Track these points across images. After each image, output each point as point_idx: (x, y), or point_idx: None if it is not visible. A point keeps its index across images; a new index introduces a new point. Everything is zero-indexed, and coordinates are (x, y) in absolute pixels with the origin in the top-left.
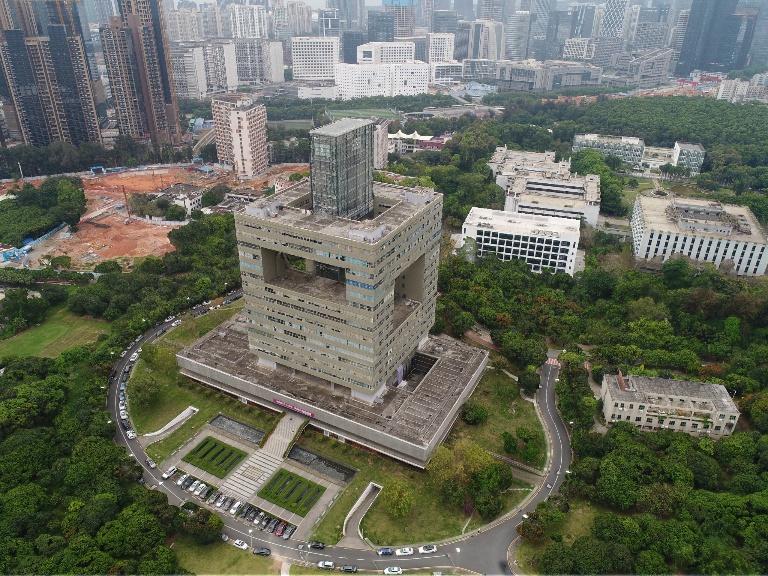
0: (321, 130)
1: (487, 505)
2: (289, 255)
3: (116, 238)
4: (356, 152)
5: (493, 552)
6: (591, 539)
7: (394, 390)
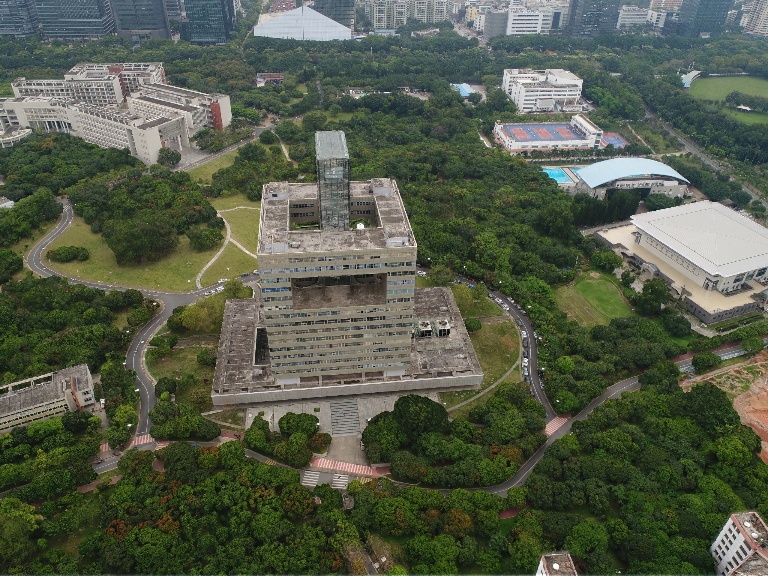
0: (339, 135)
1: (180, 306)
2: (557, 444)
3: None
4: None
5: (173, 303)
6: (114, 298)
7: None
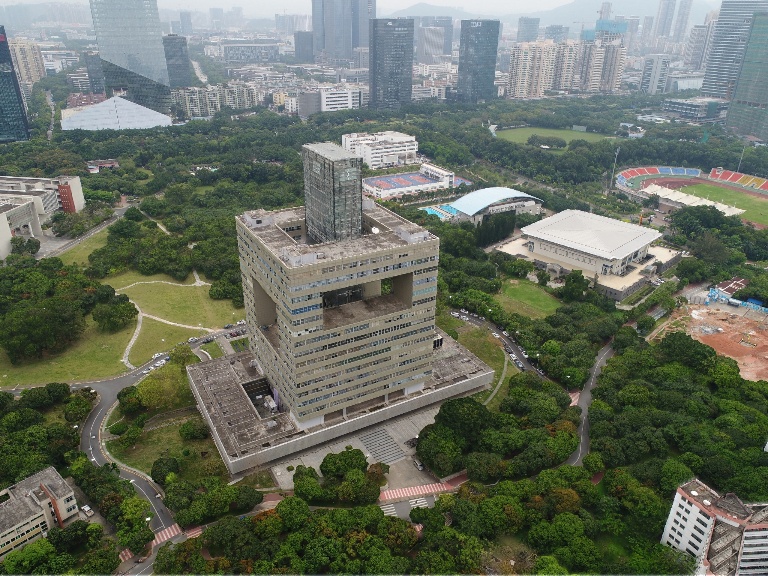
0: (329, 145)
1: (125, 388)
2: (595, 409)
3: (765, 346)
4: (318, 176)
5: (109, 390)
6: (37, 395)
7: (255, 376)
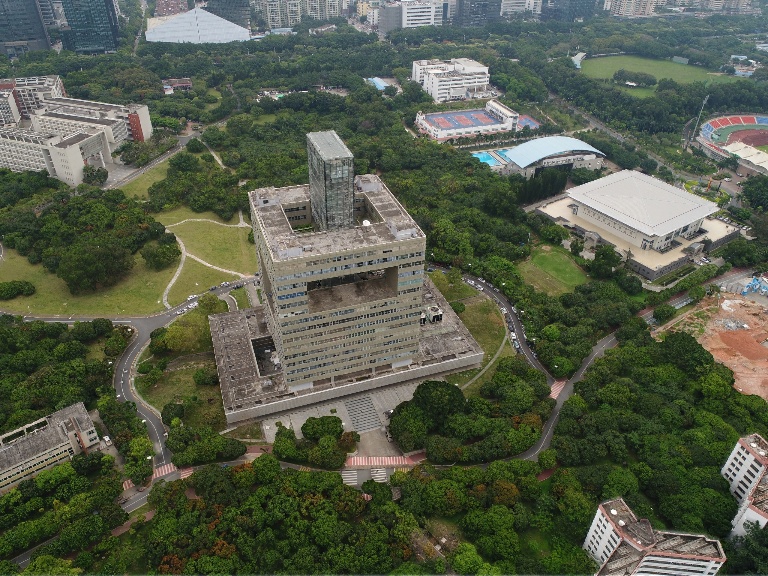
0: (332, 135)
1: (157, 329)
2: (568, 405)
3: None
4: None
5: (146, 327)
6: (84, 329)
7: (265, 333)
